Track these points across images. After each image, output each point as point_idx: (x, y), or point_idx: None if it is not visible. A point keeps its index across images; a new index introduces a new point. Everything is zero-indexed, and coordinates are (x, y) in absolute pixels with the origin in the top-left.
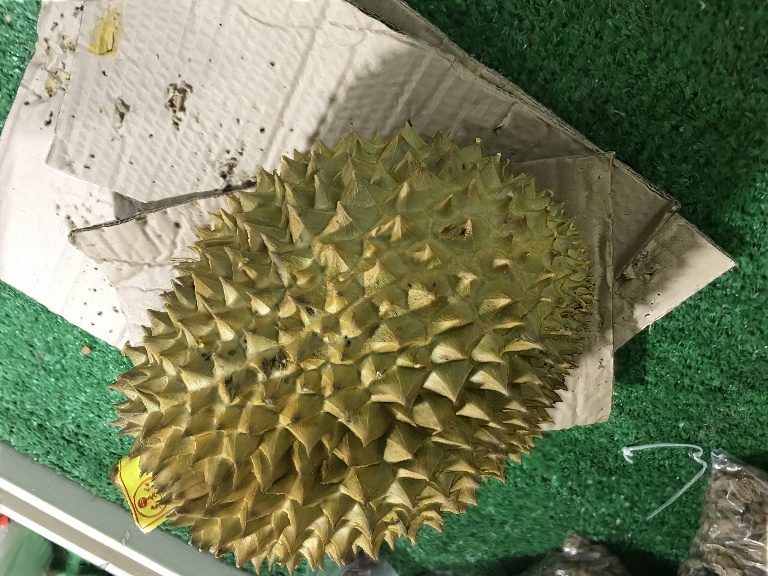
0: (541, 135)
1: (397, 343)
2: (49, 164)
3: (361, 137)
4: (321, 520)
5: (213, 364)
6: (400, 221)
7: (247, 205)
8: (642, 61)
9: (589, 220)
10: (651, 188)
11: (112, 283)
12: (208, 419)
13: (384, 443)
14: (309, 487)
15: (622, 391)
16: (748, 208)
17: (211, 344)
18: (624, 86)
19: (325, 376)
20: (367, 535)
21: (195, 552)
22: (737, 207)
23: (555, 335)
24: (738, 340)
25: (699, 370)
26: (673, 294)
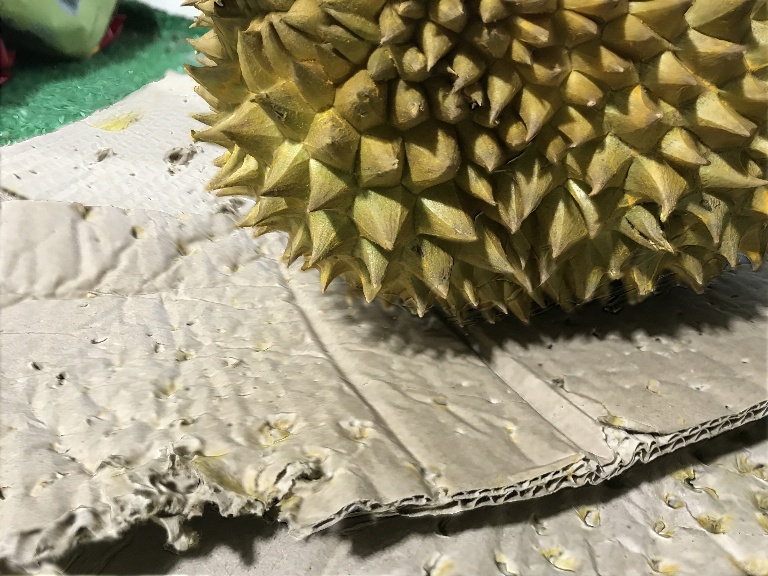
0: None
1: None
2: None
3: None
4: None
5: None
6: None
7: None
8: None
9: None
10: None
11: None
12: None
13: None
14: None
15: None
16: None
17: None
18: None
19: None
20: None
21: None
22: None
23: None
24: None
25: None
26: None
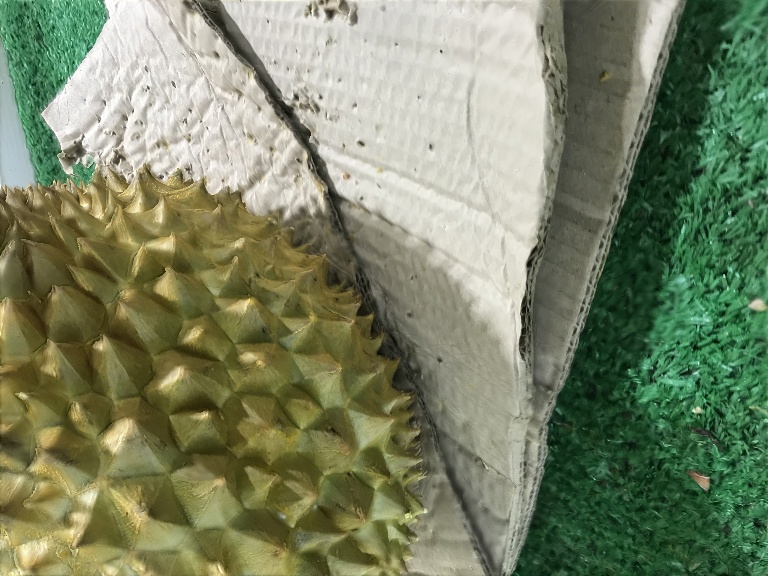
0: (496, 512)
1: None
2: None
3: (404, 292)
4: None
5: None
6: None
7: (163, 287)
8: None
9: (433, 569)
10: None
11: None
12: None
13: None
14: None
15: None
16: None
17: None
18: None
19: None
20: None
21: (27, 156)
22: None
23: None
24: None
25: None
26: None
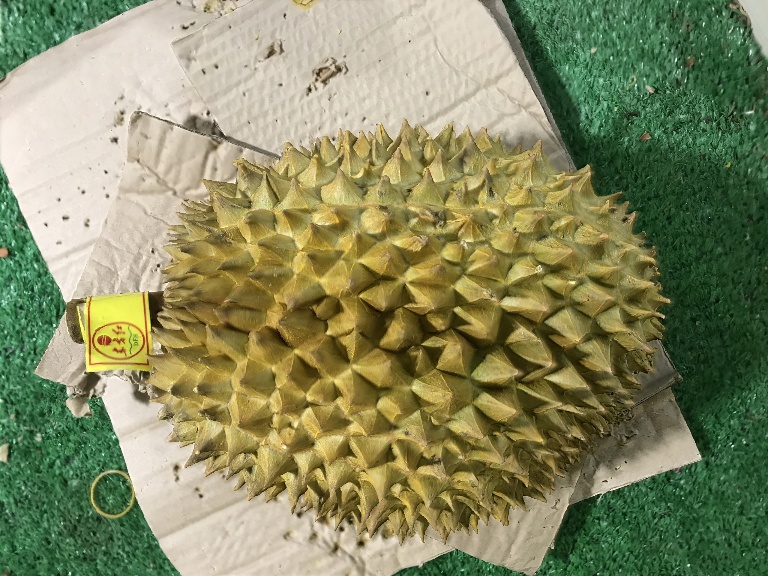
0: None
1: (569, 249)
2: (174, 46)
3: None
4: (368, 413)
5: (364, 193)
6: (588, 177)
7: None
8: (691, 255)
9: None
10: (666, 353)
11: (119, 189)
12: (334, 234)
13: (481, 358)
14: (393, 357)
15: (542, 562)
16: (722, 415)
17: (370, 178)
18: (670, 267)
19: (480, 250)
20: (403, 458)
21: None
22: (712, 412)
23: (637, 365)
24: (667, 548)
25: (620, 568)
26: (638, 467)
